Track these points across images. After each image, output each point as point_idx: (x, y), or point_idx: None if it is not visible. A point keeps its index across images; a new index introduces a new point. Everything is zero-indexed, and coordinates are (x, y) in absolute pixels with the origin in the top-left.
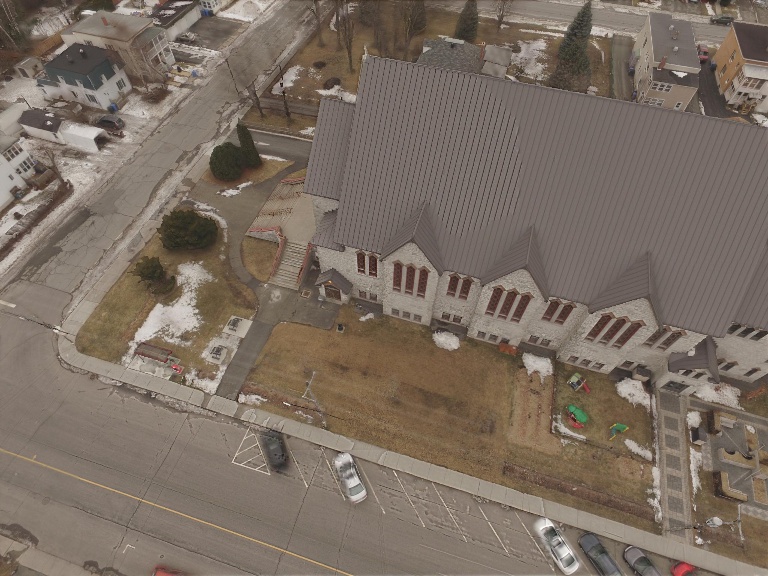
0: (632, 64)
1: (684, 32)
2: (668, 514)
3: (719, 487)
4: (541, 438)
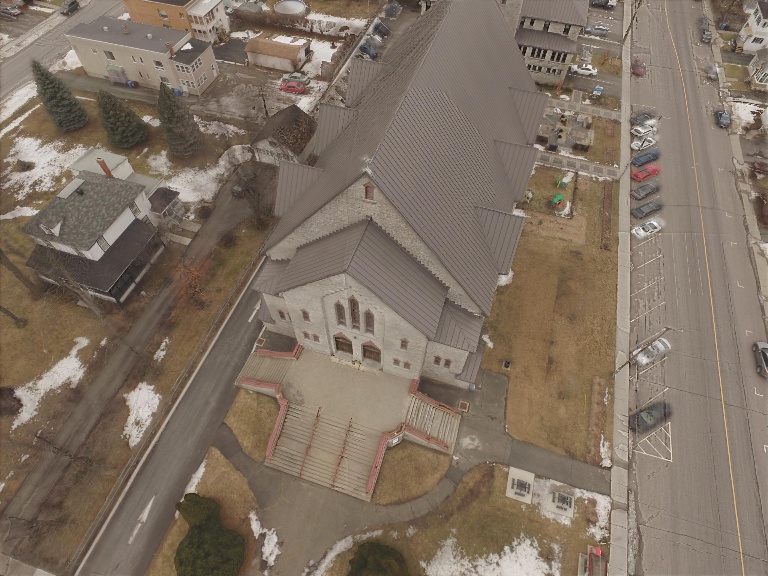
0: (124, 79)
1: (118, 24)
2: (606, 175)
3: (585, 147)
4: (577, 225)
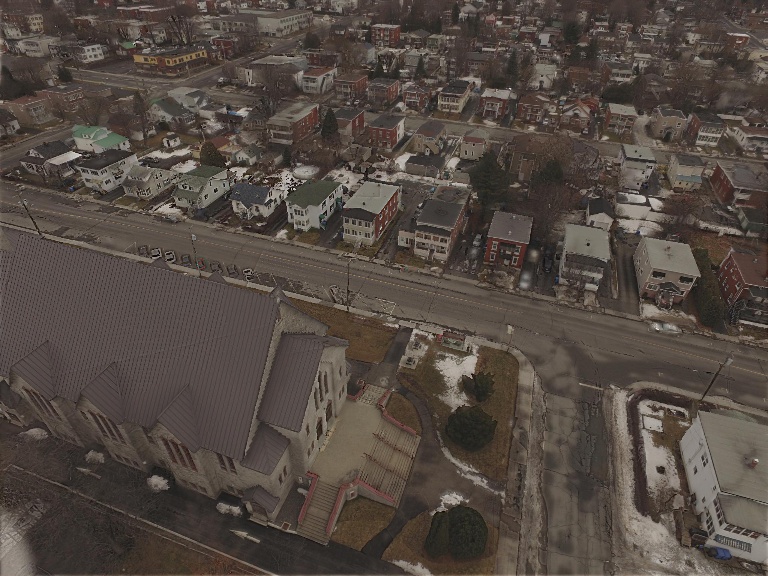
0: None
1: None
2: None
3: None
4: None
